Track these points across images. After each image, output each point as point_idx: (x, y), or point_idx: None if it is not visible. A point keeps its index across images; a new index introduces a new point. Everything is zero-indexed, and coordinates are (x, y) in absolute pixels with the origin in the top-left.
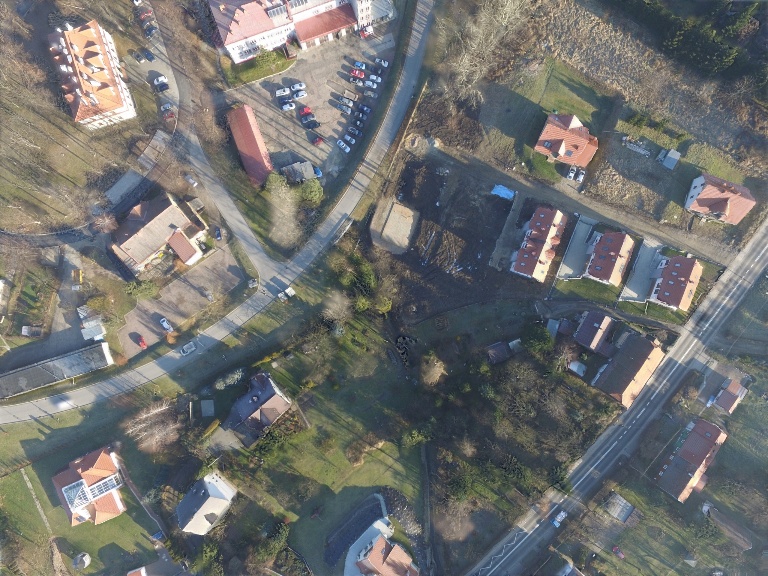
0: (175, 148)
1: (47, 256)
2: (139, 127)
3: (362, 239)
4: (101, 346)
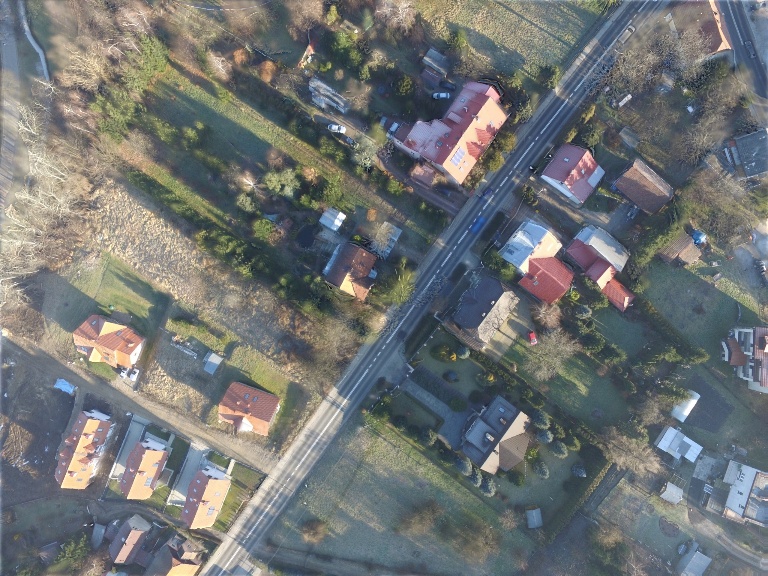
0: None
1: None
2: None
3: None
4: None
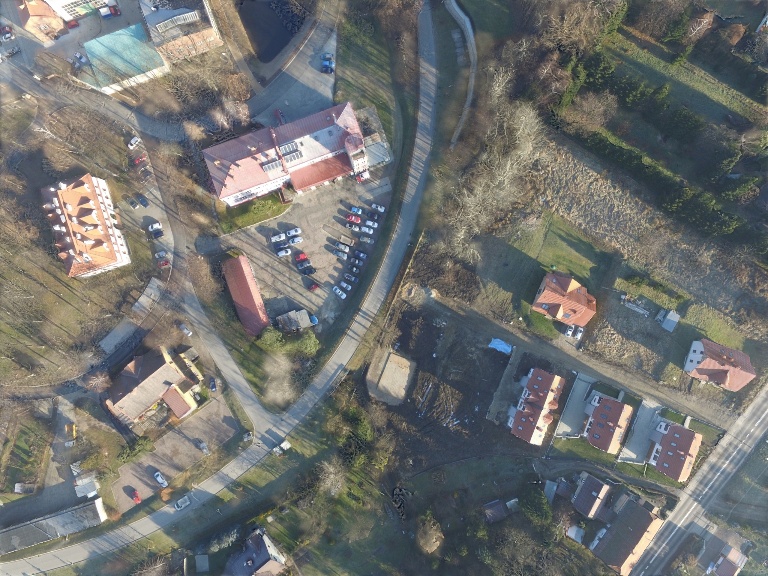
0: (170, 296)
1: (40, 408)
2: (133, 274)
3: (358, 388)
4: (94, 504)
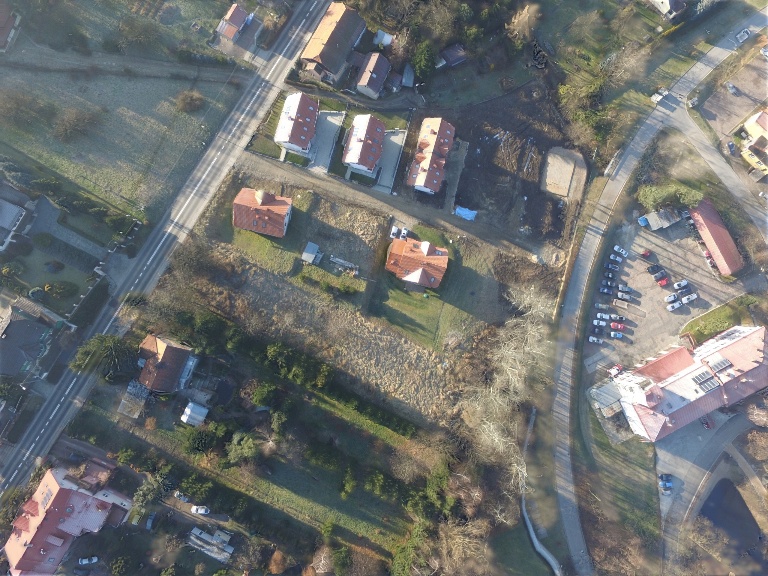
0: None
1: None
2: None
3: (590, 161)
4: None
